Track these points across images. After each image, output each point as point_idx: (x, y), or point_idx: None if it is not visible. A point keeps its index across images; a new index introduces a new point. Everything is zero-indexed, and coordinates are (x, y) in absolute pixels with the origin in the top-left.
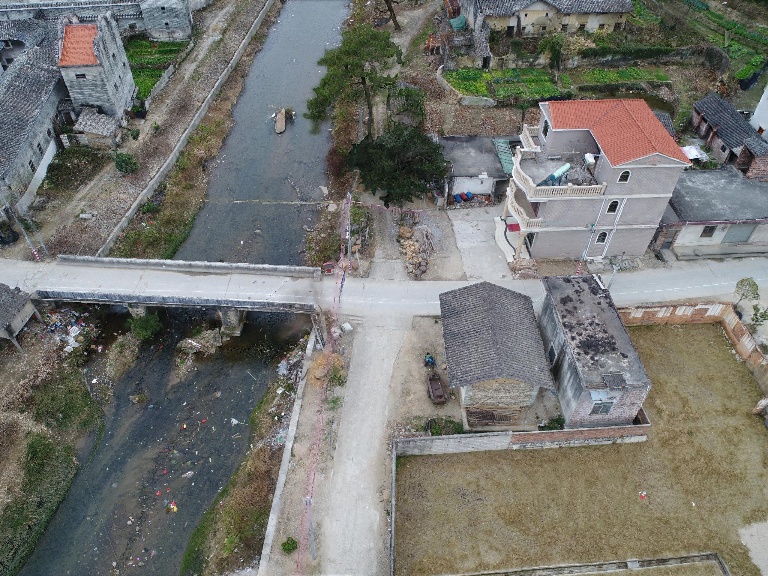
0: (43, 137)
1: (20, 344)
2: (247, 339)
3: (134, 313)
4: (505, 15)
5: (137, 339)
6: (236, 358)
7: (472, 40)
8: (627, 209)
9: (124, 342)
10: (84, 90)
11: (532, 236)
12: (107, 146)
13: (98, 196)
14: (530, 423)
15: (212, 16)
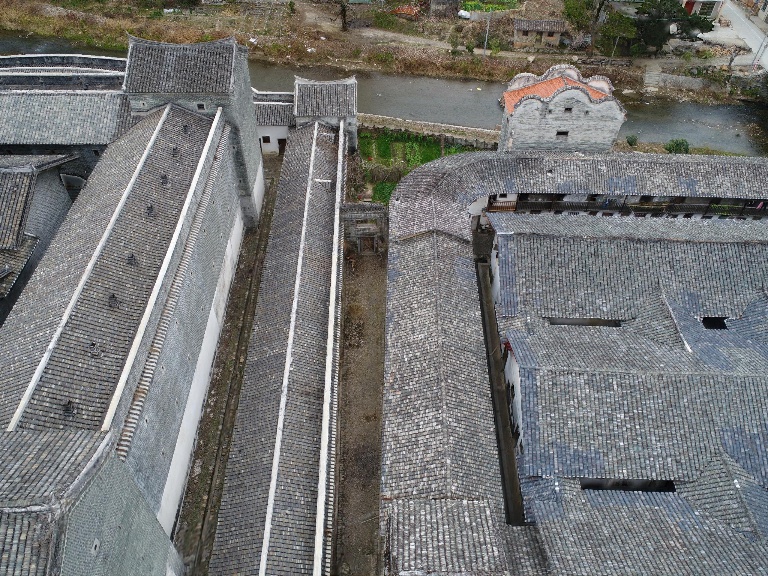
0: None
1: None
2: None
3: None
4: None
5: None
6: None
7: None
8: None
9: None
10: None
11: (710, 8)
12: None
13: None
14: None
15: None
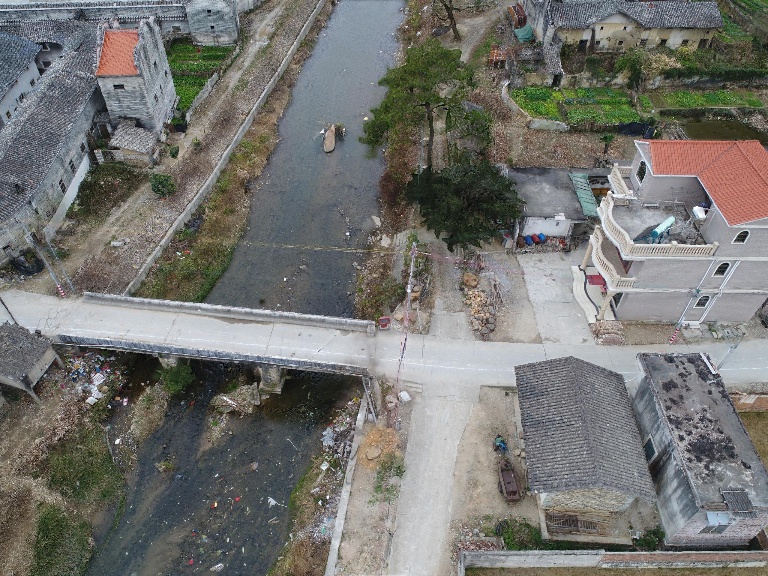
0: (76, 153)
1: (38, 394)
2: (288, 398)
3: (164, 363)
4: (579, 28)
5: (166, 392)
6: (276, 421)
7: (542, 55)
8: (738, 272)
9: (152, 395)
10: (122, 102)
11: (619, 294)
12: (144, 163)
13: (131, 221)
14: (622, 534)
15: (260, 19)
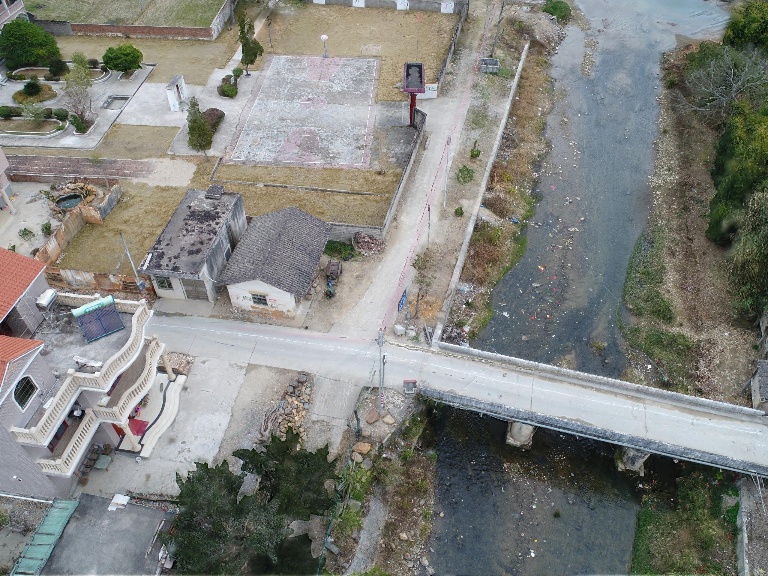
0: None
1: (749, 398)
2: None
3: None
4: None
5: None
6: None
7: None
8: None
9: None
10: None
11: None
12: None
13: None
14: None
15: None
